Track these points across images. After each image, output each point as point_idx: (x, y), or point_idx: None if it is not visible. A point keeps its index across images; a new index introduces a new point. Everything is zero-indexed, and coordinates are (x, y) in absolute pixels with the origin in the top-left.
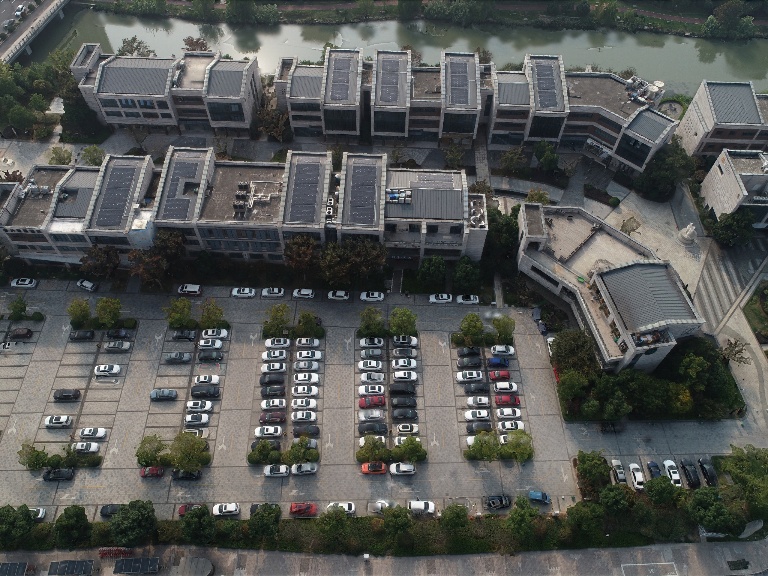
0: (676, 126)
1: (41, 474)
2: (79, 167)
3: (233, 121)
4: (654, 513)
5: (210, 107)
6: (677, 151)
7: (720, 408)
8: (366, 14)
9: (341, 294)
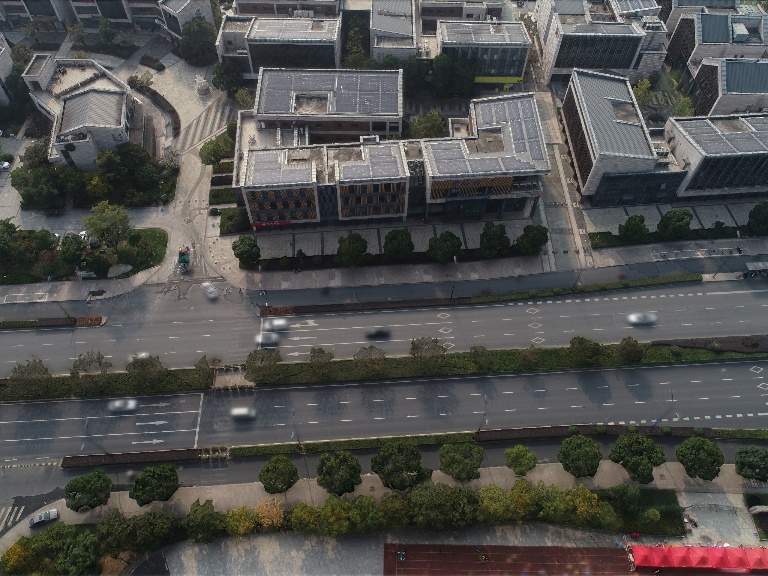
0: (207, 2)
1: None
2: None
3: None
4: (28, 254)
5: None
6: (196, 20)
7: (139, 195)
8: None
9: None
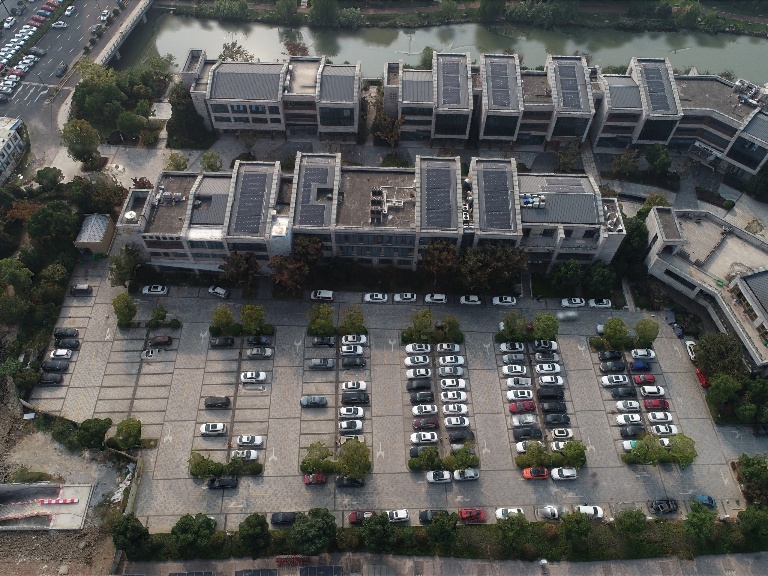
0: None
1: (204, 482)
2: (207, 173)
3: (342, 126)
4: None
5: (321, 112)
6: None
7: None
8: (448, 17)
9: (474, 299)
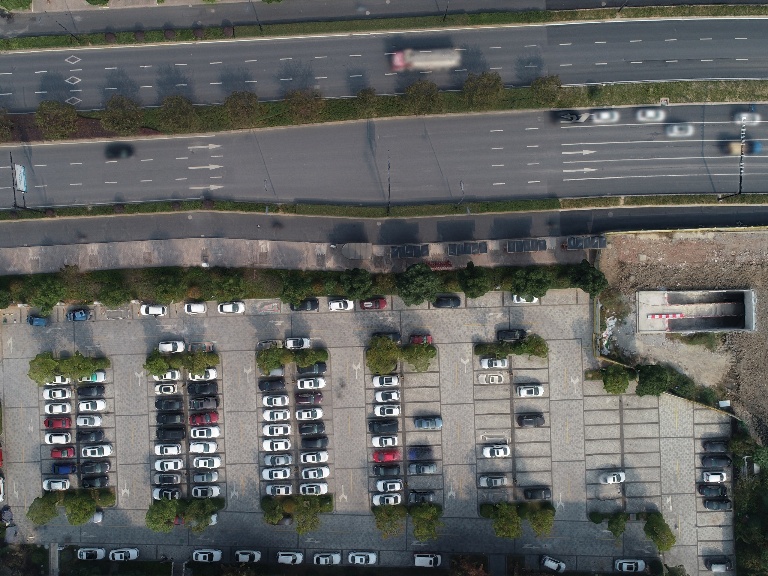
0: None
1: None
2: None
3: None
4: None
5: None
6: None
7: None
8: None
9: (243, 557)
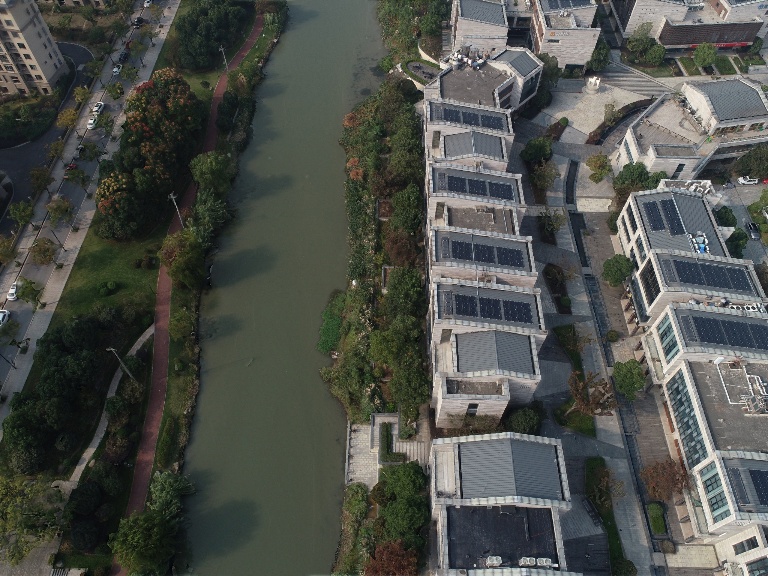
0: None
1: None
2: None
3: None
4: None
5: None
6: (542, 57)
7: None
8: None
9: None
